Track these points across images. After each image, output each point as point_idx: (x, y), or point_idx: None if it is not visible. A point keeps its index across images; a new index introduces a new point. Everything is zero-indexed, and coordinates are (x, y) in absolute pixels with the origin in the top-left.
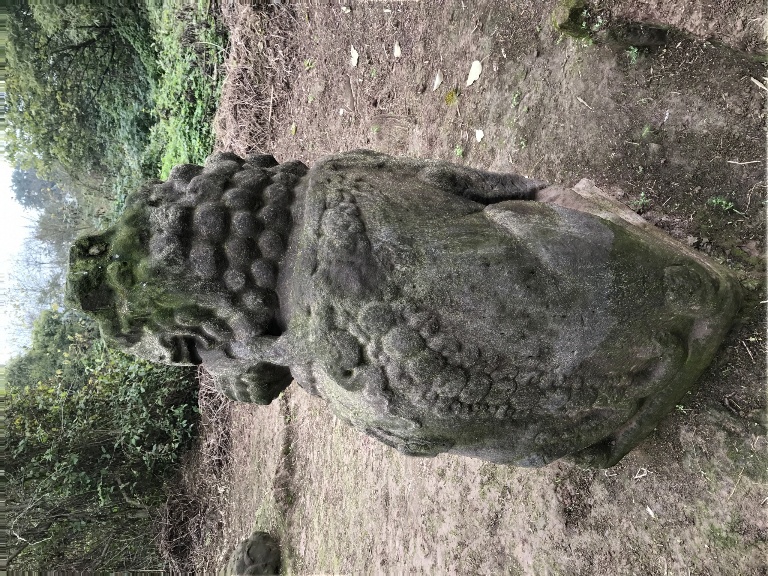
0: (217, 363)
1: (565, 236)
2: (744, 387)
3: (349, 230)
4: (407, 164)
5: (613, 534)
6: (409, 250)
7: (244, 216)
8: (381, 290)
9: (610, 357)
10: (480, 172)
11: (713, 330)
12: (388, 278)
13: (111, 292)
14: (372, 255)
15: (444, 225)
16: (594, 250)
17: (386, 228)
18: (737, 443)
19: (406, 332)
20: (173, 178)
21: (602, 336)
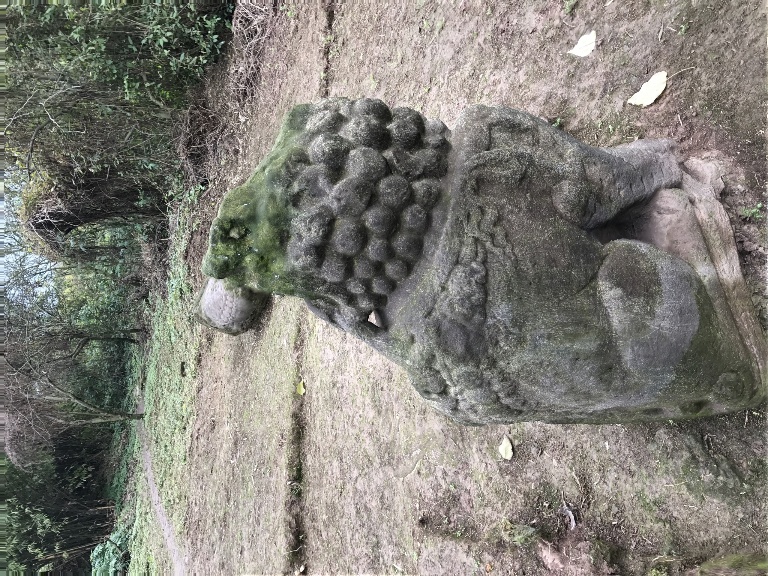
0: None
1: (655, 335)
2: (725, 437)
3: (472, 301)
4: (548, 169)
5: (573, 436)
6: (517, 334)
7: (381, 248)
8: (480, 359)
9: (637, 407)
10: (616, 169)
11: (728, 411)
12: (490, 351)
13: (244, 267)
14: (484, 328)
15: (556, 311)
16: (672, 353)
17: (505, 306)
18: (694, 467)
19: (487, 394)
20: (317, 160)
21: (639, 404)
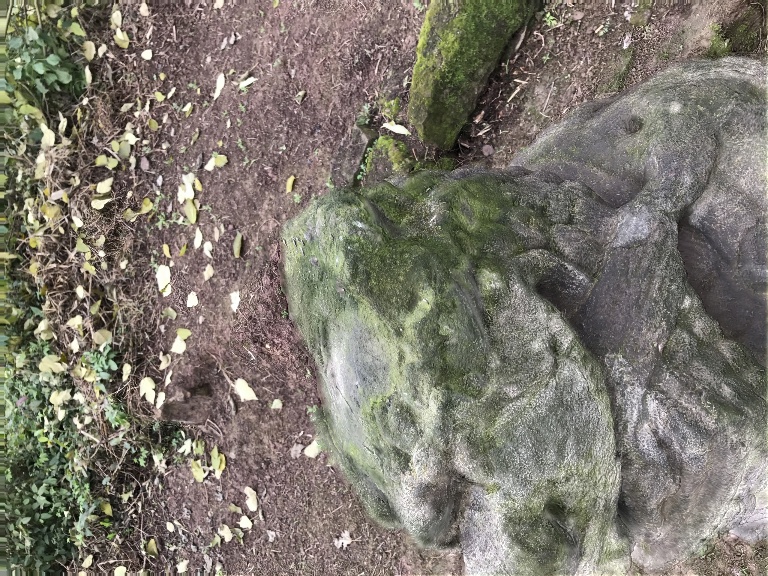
0: (635, 281)
1: None
2: None
3: None
4: None
5: None
6: None
7: None
8: None
9: None
10: None
11: None
12: None
13: None
14: None
15: None
16: None
17: None
18: None
19: None
20: None
21: None
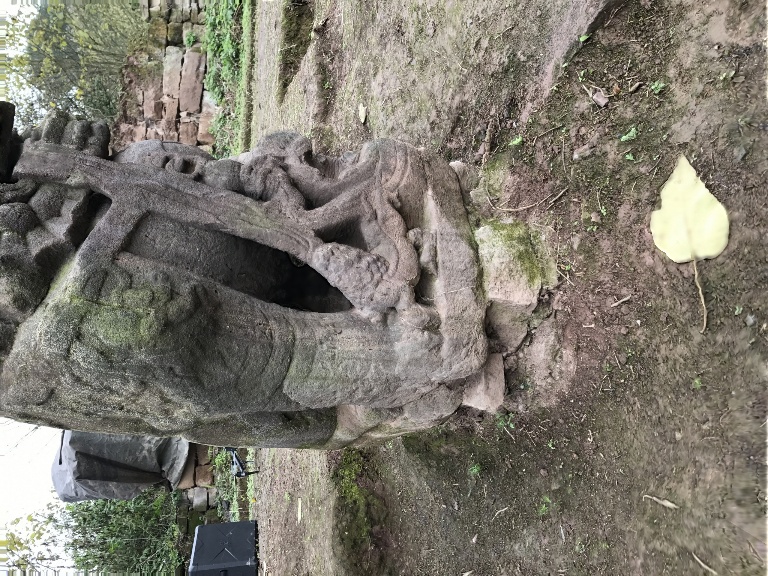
0: None
1: None
2: None
3: None
4: (136, 416)
5: None
6: None
7: None
8: None
9: None
10: None
11: None
12: None
13: None
14: None
15: None
16: None
17: None
18: None
19: None
20: None
21: None
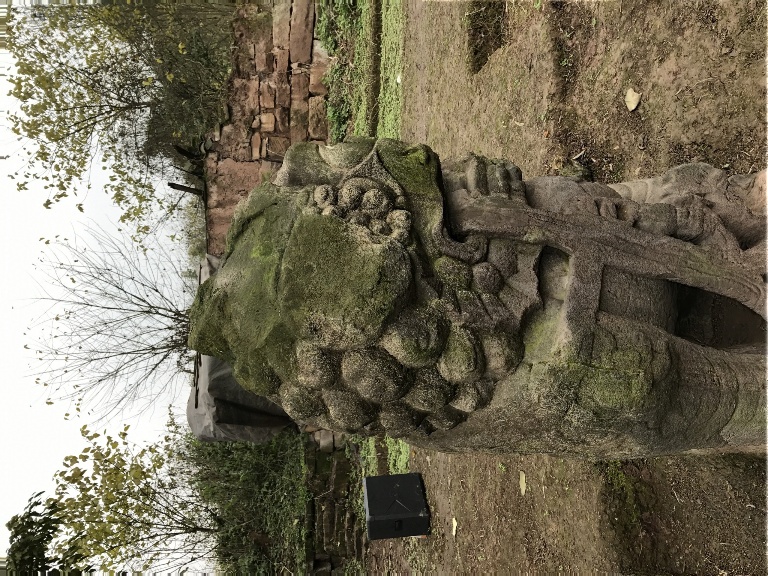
0: None
1: None
2: None
3: None
4: None
5: None
6: None
7: None
8: None
9: None
10: None
11: None
12: None
13: None
14: None
15: None
16: None
17: None
18: None
19: None
20: None
21: None
